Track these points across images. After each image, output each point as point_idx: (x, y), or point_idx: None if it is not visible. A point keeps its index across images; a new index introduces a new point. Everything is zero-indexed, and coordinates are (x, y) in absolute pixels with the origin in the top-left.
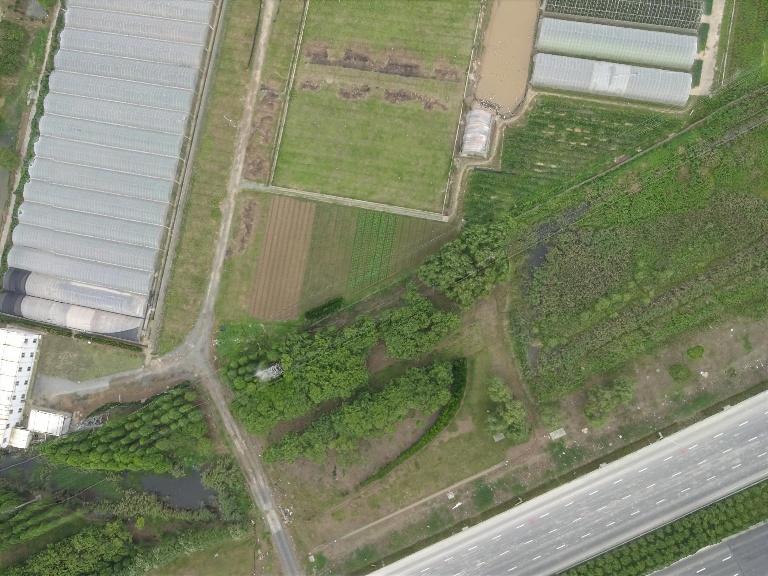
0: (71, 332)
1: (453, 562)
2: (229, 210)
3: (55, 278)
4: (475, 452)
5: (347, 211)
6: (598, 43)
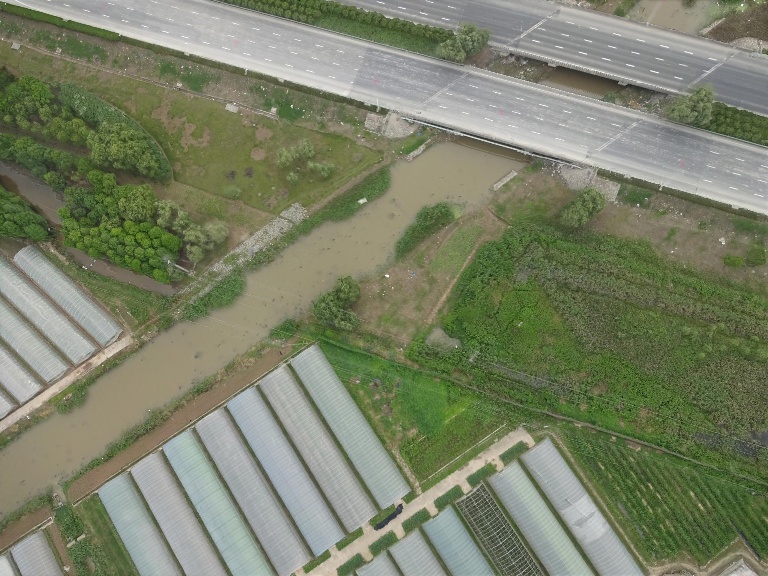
0: None
1: None
2: None
3: None
4: None
5: None
6: (570, 557)
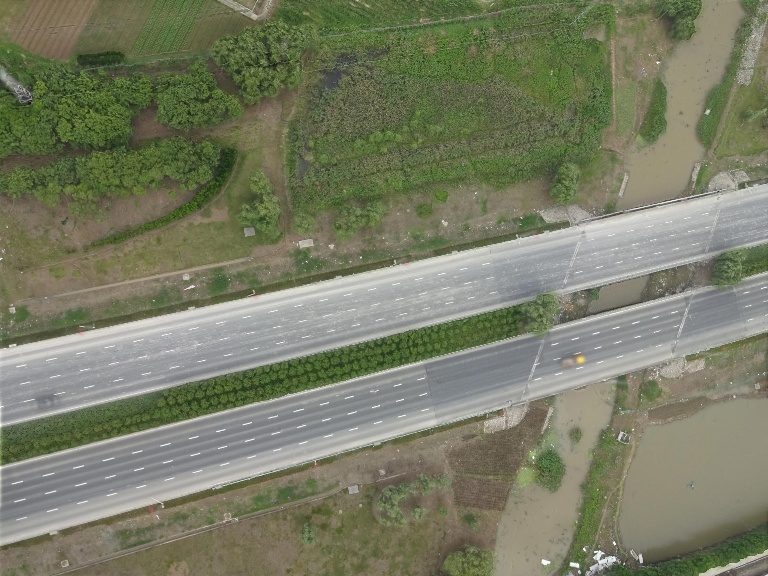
0: None
1: (170, 338)
2: None
3: None
4: (222, 242)
5: None
6: None
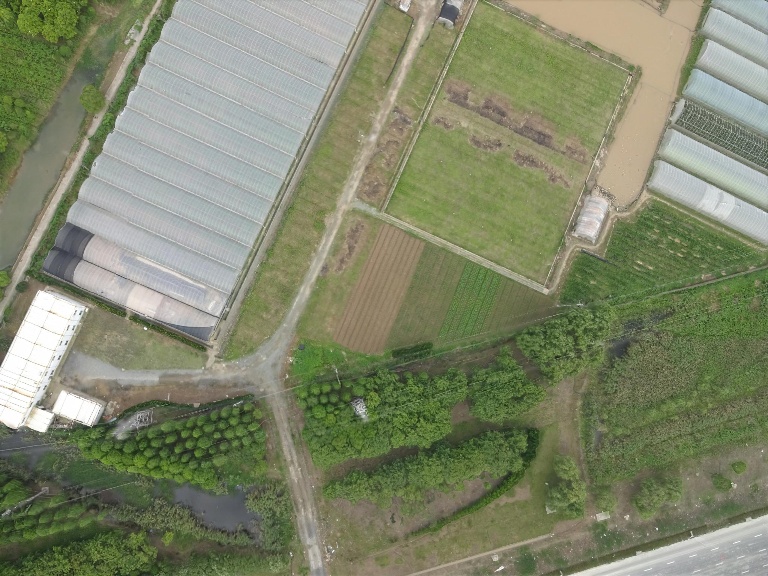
0: (125, 312)
1: None
2: (334, 225)
3: (123, 249)
4: (526, 520)
5: (455, 259)
6: (714, 168)
